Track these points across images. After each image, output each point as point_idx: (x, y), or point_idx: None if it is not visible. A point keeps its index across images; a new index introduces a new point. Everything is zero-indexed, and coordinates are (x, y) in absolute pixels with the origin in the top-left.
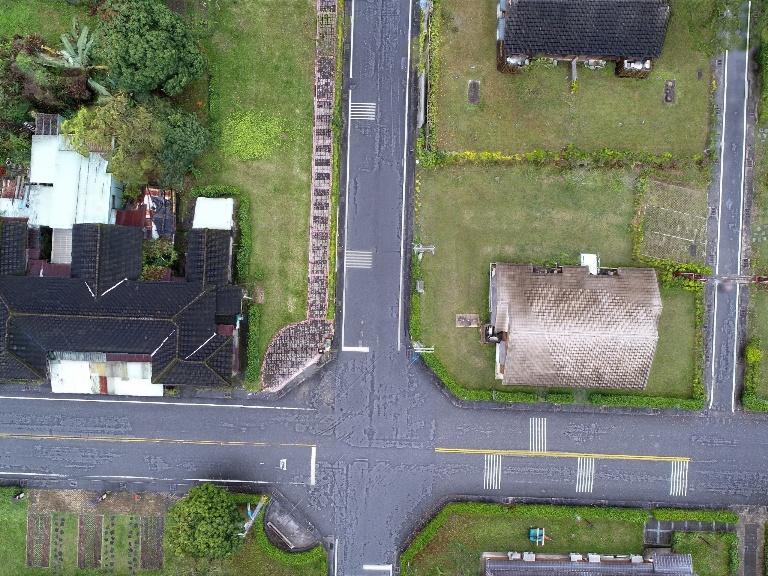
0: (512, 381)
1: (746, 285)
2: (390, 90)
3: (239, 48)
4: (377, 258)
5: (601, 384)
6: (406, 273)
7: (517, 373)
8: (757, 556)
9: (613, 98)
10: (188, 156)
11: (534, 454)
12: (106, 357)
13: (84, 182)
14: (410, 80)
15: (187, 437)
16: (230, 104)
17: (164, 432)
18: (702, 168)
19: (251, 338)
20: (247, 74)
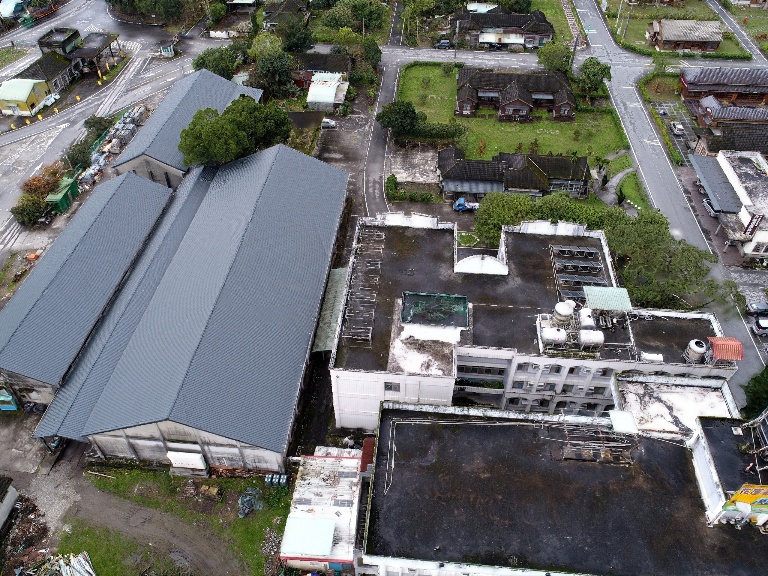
0: (667, 38)
1: (751, 39)
2: (590, 7)
3: (533, 1)
4: None
5: (704, 39)
6: (611, 34)
7: (668, 35)
8: None
9: (674, 10)
10: (526, 3)
11: (685, 66)
12: (503, 31)
13: (488, 7)
14: (597, 6)
15: (532, 59)
16: (533, 8)
17: (522, 58)
18: (716, 20)
19: None
20: (537, 4)
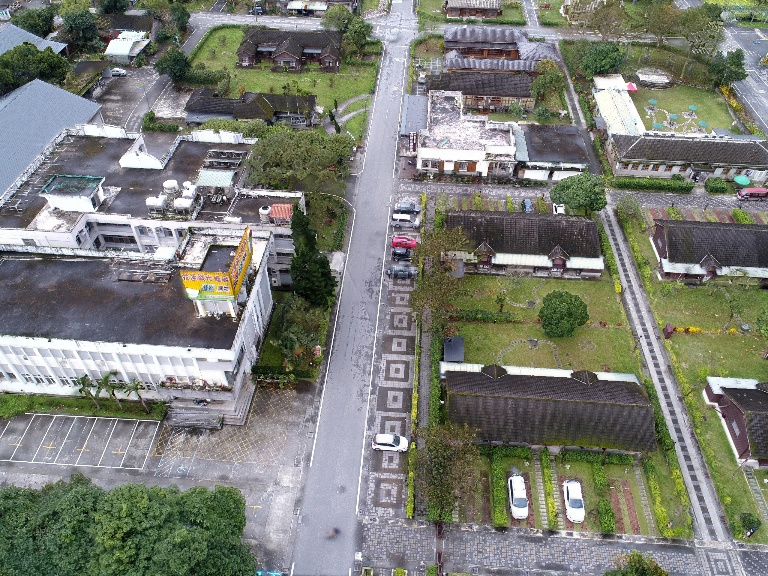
0: (451, 5)
1: None
2: None
3: None
4: (404, 1)
5: (483, 6)
6: None
7: (453, 3)
8: (557, 49)
9: None
10: None
11: None
12: None
13: None
14: None
15: None
16: None
17: None
18: None
19: (359, 6)
20: None
